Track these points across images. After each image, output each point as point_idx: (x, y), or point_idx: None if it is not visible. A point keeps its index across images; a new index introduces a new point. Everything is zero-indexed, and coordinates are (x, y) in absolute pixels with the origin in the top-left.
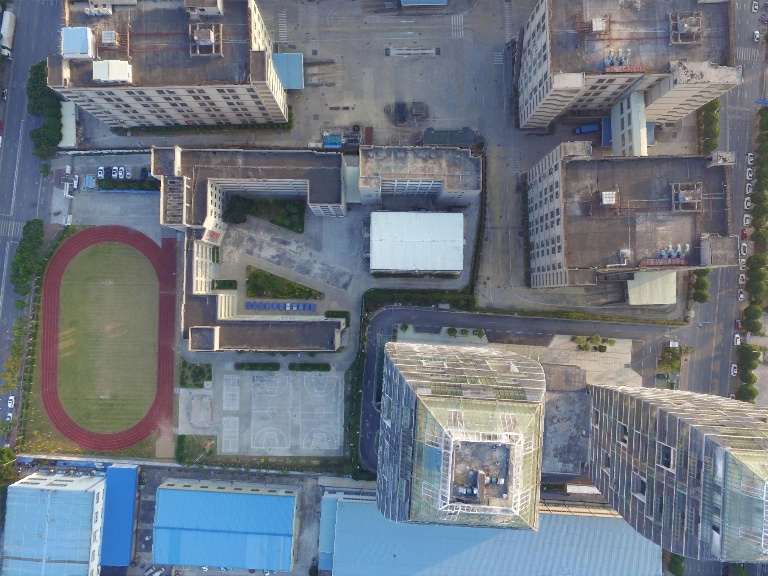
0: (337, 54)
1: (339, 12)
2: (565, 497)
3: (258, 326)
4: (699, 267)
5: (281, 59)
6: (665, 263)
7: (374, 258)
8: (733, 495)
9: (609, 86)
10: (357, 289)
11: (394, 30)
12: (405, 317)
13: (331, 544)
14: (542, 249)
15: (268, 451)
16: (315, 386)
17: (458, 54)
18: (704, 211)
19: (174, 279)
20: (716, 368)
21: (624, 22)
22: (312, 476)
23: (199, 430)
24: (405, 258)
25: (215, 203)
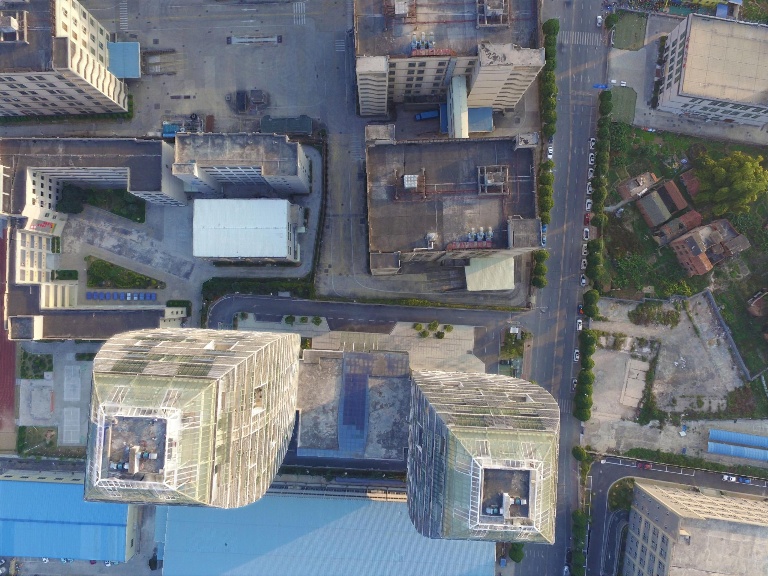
0: (178, 43)
1: (180, 1)
2: None
3: (82, 315)
4: (508, 250)
5: (117, 48)
6: (471, 246)
7: (197, 245)
8: (452, 472)
9: (425, 70)
10: (199, 278)
11: (236, 18)
12: (246, 306)
13: None
14: None
15: None
16: None
17: (300, 42)
18: (511, 194)
19: None
20: (559, 354)
21: (432, 5)
22: None
23: (40, 421)
24: (228, 245)
25: (42, 192)
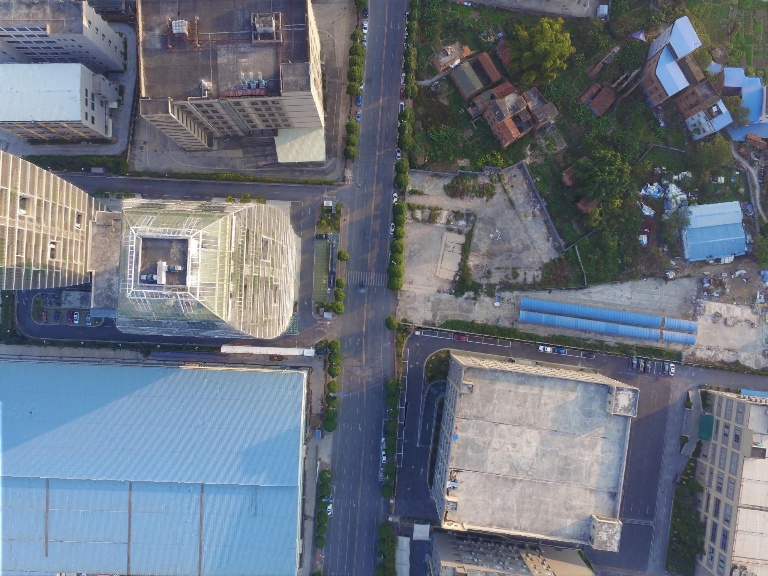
0: None
1: None
2: (226, 360)
3: None
4: (285, 99)
5: None
6: (244, 94)
7: None
8: None
9: None
10: None
11: None
12: None
13: None
14: None
15: None
16: None
17: None
18: (286, 42)
19: None
20: (375, 228)
21: None
22: None
23: None
24: (21, 109)
25: None
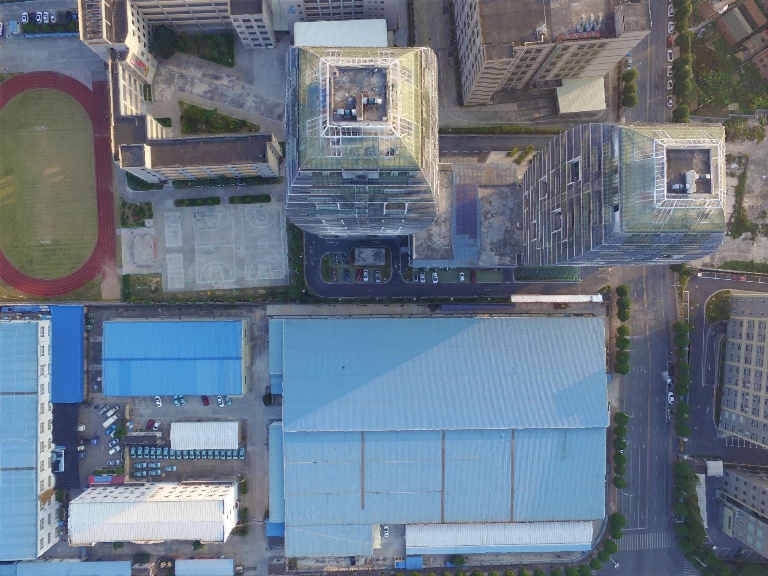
0: None
1: None
2: (511, 310)
3: (189, 144)
4: (615, 42)
5: None
6: (581, 37)
7: None
8: (628, 167)
9: None
10: None
11: None
12: None
13: (281, 365)
14: (467, 53)
15: (214, 285)
16: (257, 218)
17: None
18: None
19: (108, 121)
20: None
21: None
22: (260, 307)
23: (143, 269)
24: None
25: (138, 28)
